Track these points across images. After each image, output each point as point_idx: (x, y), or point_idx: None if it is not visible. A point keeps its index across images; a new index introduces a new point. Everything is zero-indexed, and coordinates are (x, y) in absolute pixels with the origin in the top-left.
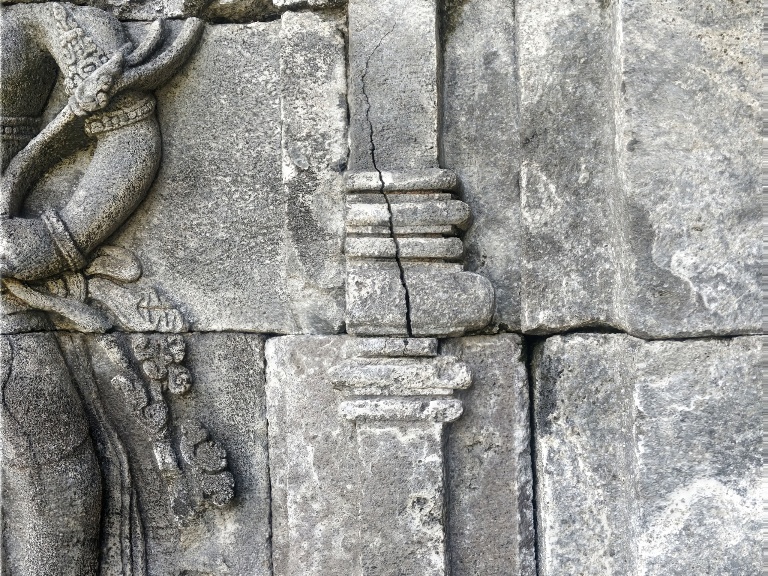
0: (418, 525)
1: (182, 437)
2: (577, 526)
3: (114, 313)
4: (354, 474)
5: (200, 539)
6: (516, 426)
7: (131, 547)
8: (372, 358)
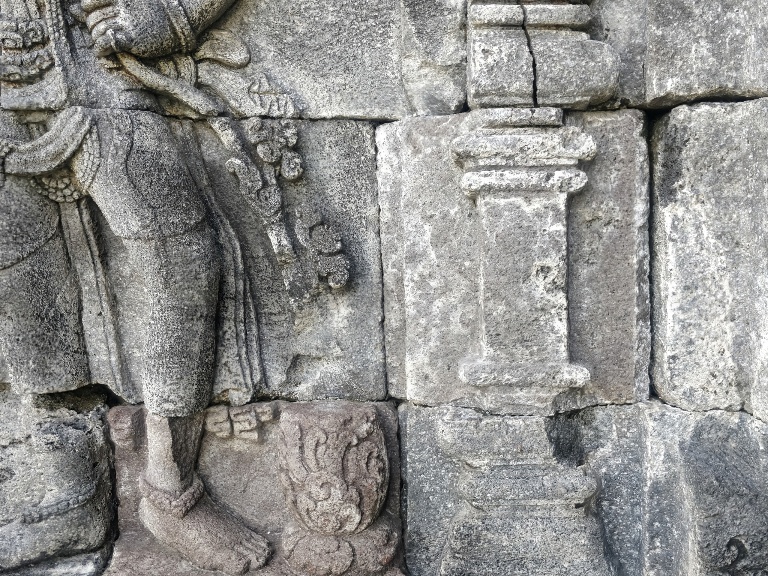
0: (542, 293)
1: (297, 220)
2: (699, 292)
3: (224, 99)
4: (472, 251)
5: (313, 323)
6: (636, 200)
7: (245, 331)
8: (497, 128)
